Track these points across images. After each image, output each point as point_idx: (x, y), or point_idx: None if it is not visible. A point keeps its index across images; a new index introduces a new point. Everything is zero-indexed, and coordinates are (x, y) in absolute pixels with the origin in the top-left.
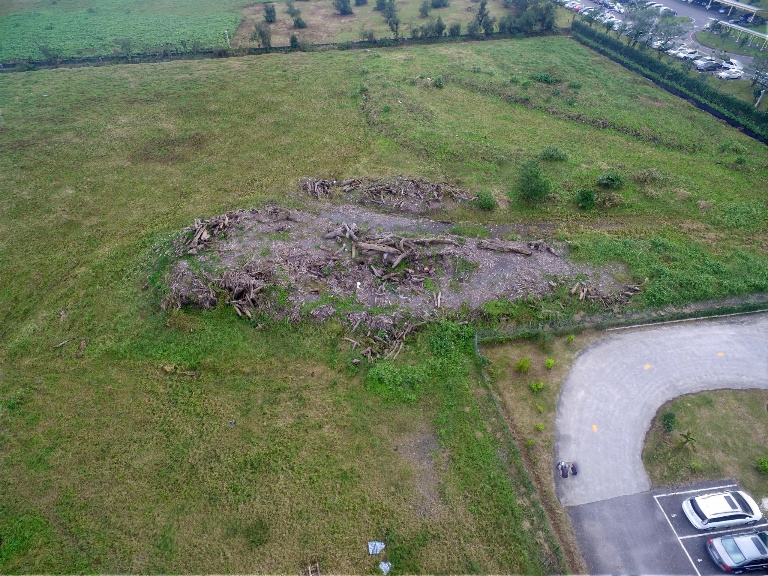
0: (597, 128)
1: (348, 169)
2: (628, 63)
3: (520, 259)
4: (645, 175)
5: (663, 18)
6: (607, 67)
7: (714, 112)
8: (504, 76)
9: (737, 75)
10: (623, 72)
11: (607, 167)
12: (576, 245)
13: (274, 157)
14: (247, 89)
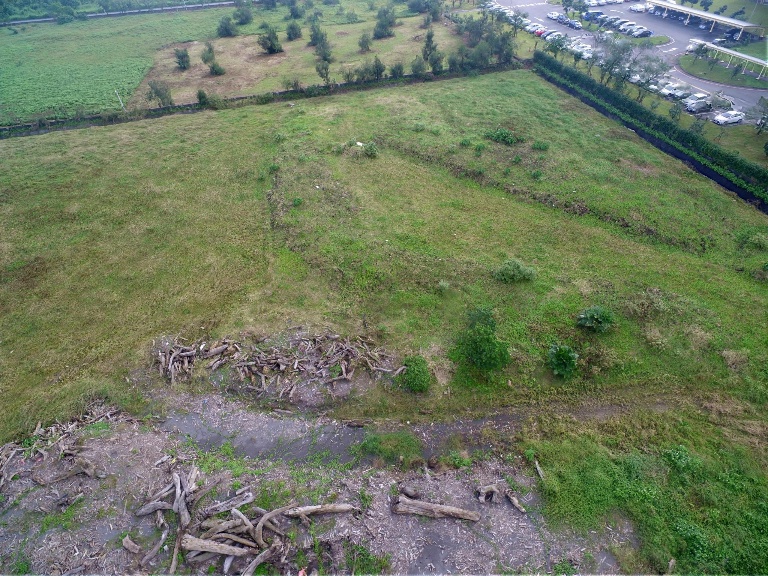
0: (572, 215)
1: (229, 315)
2: (603, 106)
3: (461, 533)
4: (644, 306)
5: (641, 50)
6: (578, 114)
7: (718, 177)
8: (453, 135)
9: (737, 118)
10: (598, 120)
11: (589, 289)
12: (552, 489)
13: (130, 297)
14: (128, 174)
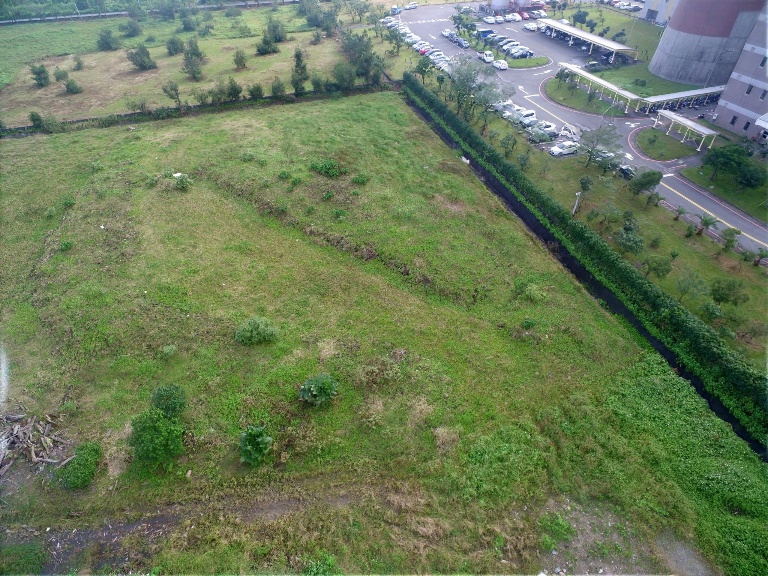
0: (358, 260)
1: None
2: (449, 134)
3: None
4: (372, 375)
5: (485, 76)
6: (418, 143)
7: (529, 215)
8: (280, 166)
9: (572, 149)
10: (437, 150)
11: (331, 352)
12: None
13: None
14: None
